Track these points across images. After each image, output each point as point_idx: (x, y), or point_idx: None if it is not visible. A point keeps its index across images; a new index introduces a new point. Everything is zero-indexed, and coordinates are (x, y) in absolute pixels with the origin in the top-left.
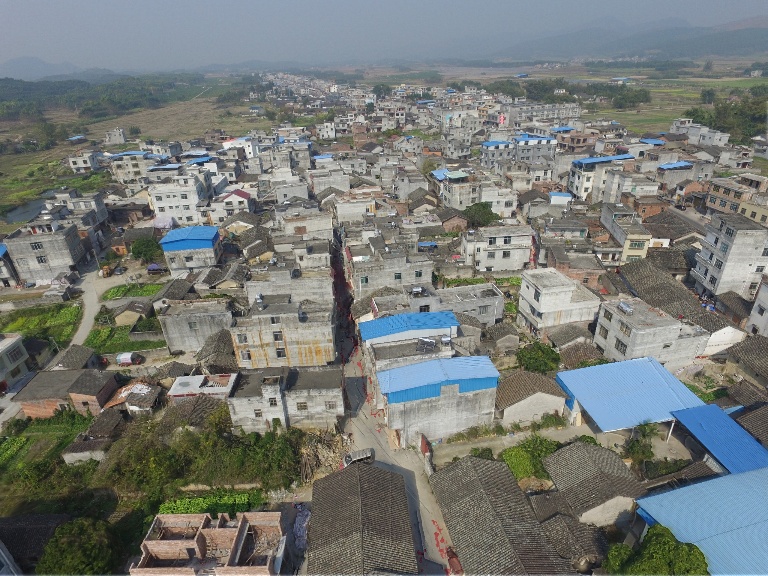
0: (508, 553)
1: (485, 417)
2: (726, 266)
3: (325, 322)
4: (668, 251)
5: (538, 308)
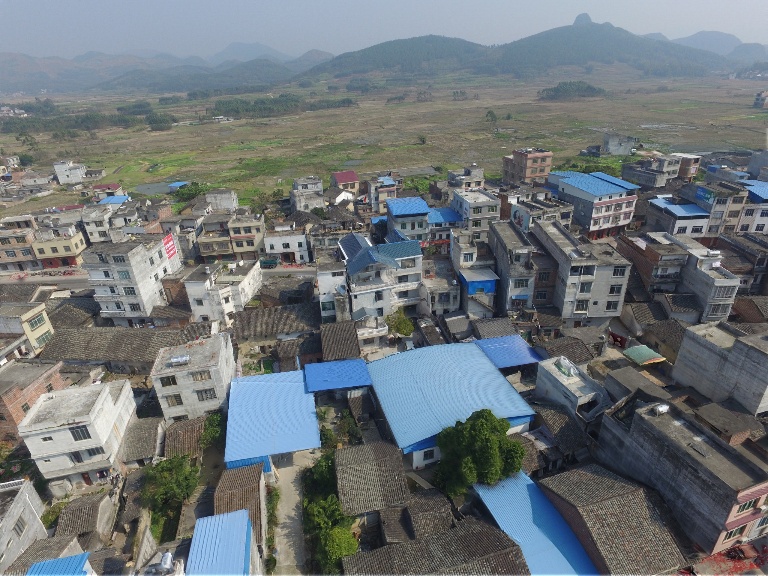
0: (478, 568)
1: (260, 572)
2: (139, 288)
3: None
4: (57, 312)
5: (96, 444)
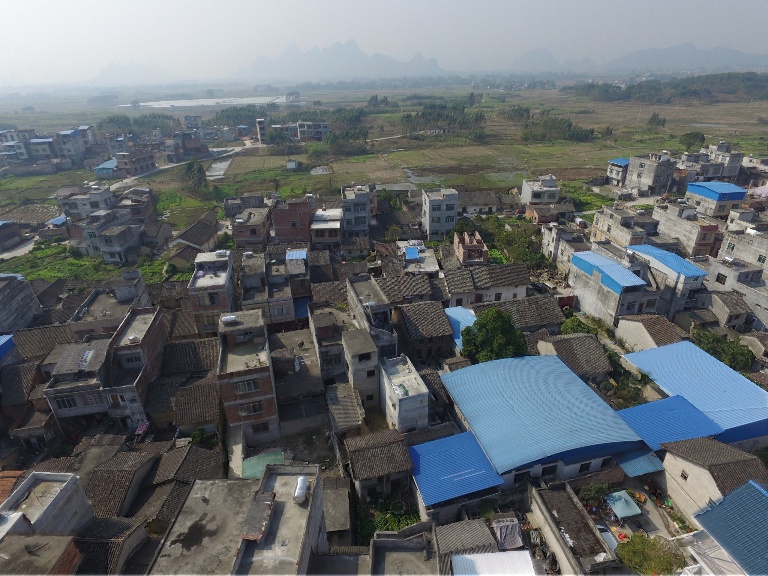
0: None
1: (609, 317)
2: None
3: (629, 231)
4: None
5: None
